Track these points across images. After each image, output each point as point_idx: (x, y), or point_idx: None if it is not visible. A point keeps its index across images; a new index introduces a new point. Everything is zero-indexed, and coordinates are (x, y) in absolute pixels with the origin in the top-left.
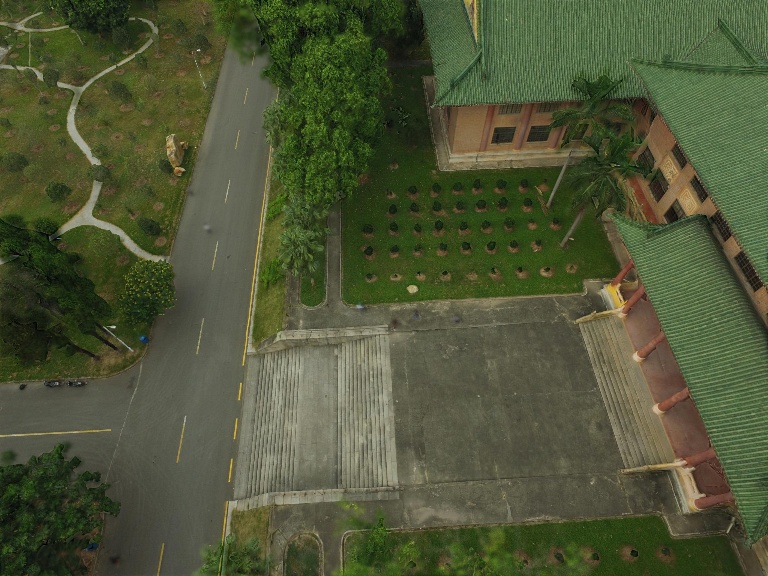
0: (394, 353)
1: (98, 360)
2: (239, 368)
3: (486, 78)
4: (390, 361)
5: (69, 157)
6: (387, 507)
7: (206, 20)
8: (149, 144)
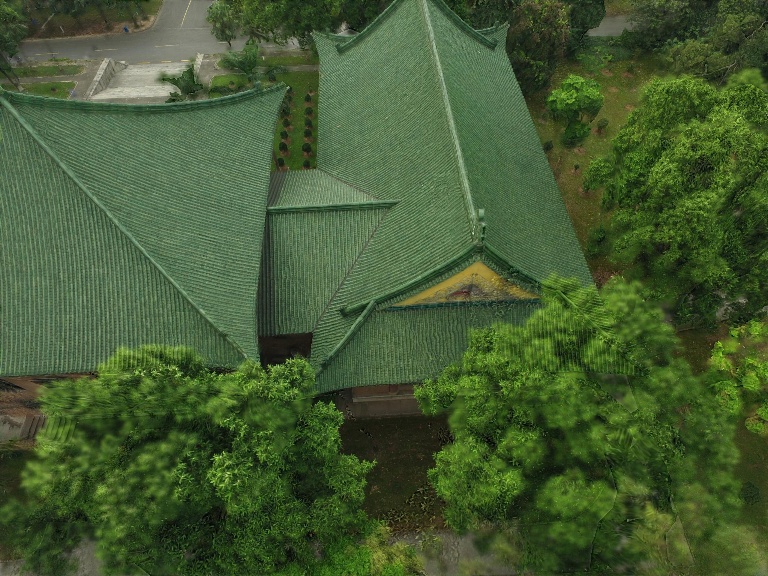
0: (171, 97)
1: None
2: None
3: (341, 56)
4: (166, 96)
5: None
6: (81, 95)
7: None
8: None
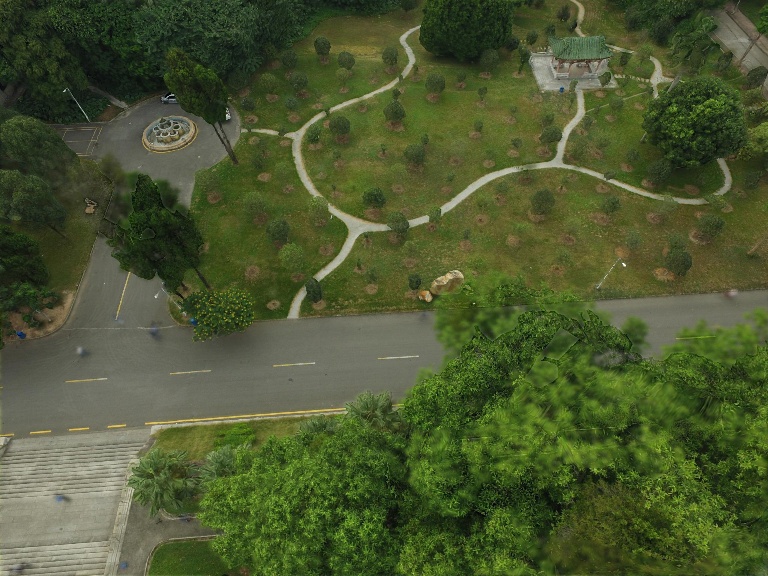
0: None
1: (184, 290)
2: (143, 420)
3: None
4: None
5: (444, 189)
6: None
7: (764, 252)
8: (474, 253)
